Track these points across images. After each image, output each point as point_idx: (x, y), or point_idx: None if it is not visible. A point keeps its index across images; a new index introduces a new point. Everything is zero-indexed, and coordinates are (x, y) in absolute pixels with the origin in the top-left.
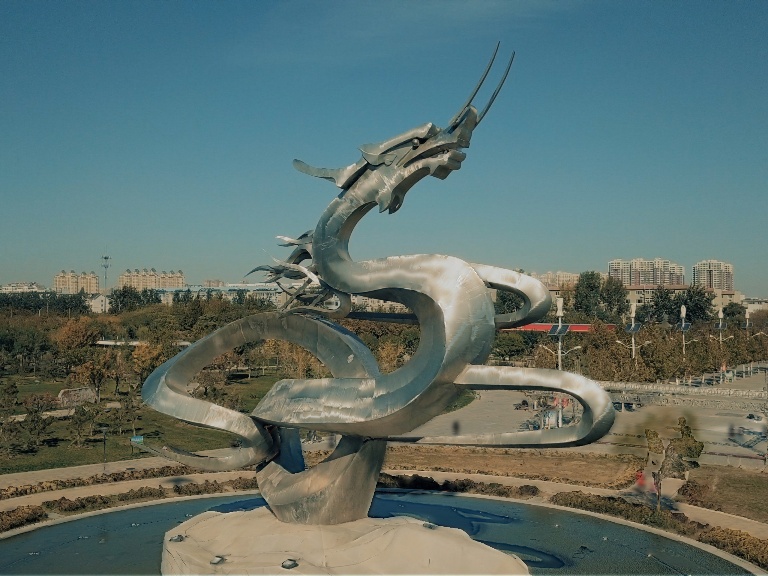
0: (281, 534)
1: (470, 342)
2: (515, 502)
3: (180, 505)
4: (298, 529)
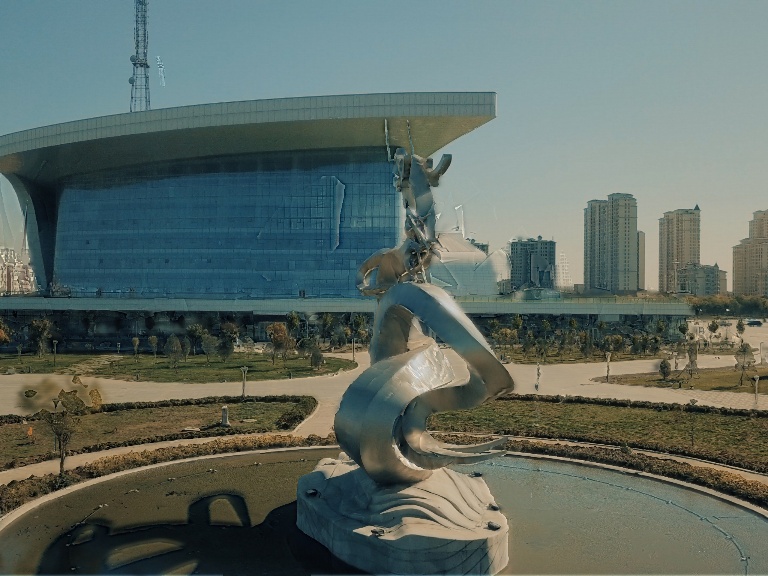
0: None
1: None
2: None
3: None
4: None
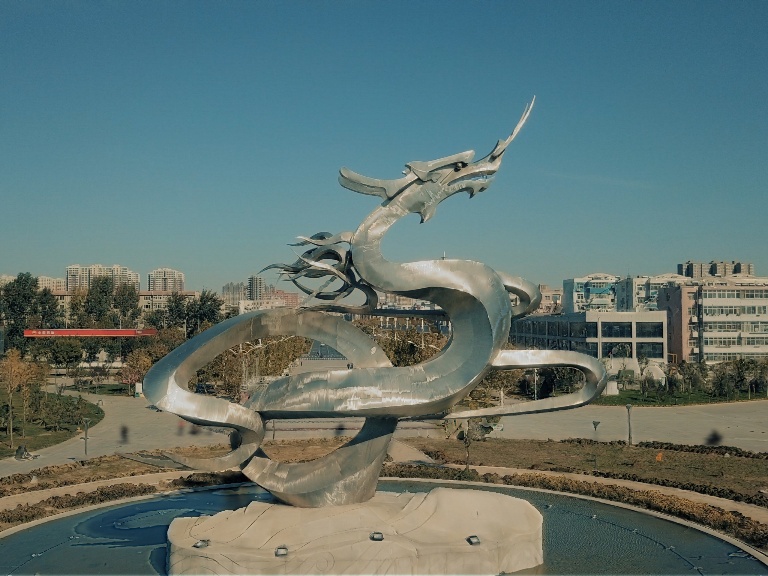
0: (331, 517)
1: (502, 332)
2: None
3: (36, 531)
4: (342, 510)
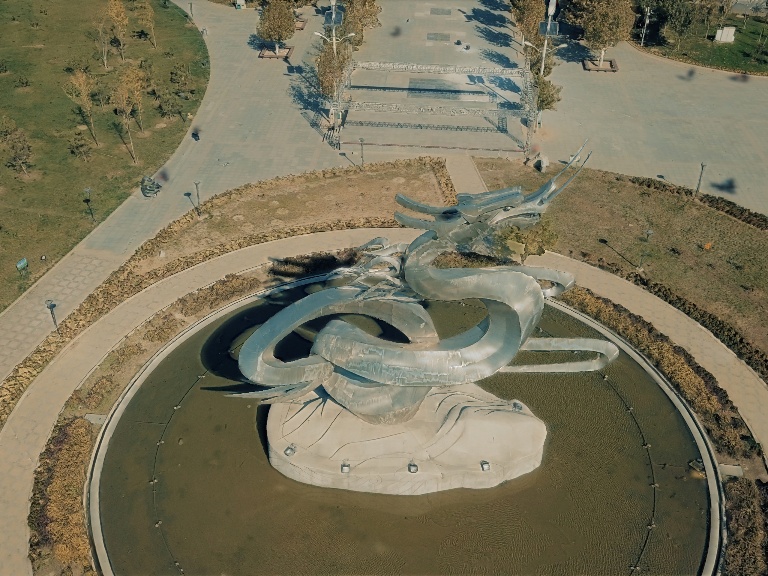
0: (383, 439)
1: None
2: None
3: (173, 361)
4: (391, 431)
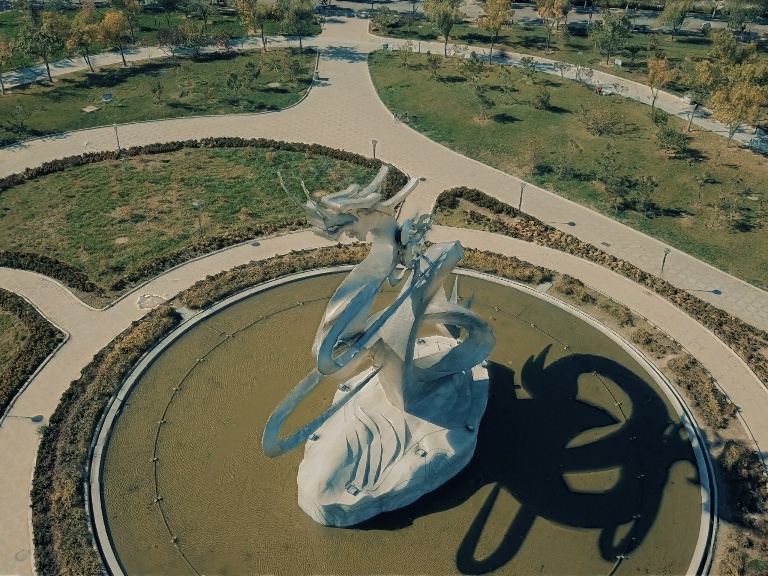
0: None
1: None
2: (685, 575)
3: (600, 338)
4: None
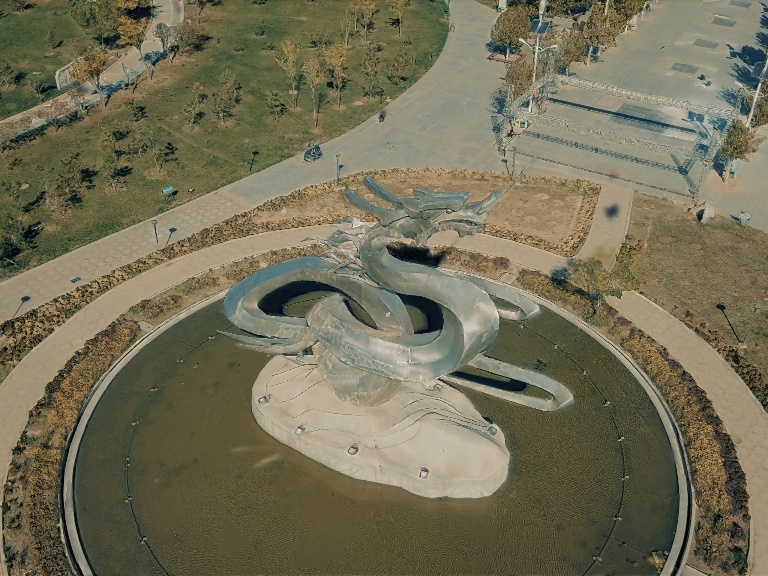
0: (341, 415)
1: (481, 343)
2: None
3: None
4: (352, 411)
